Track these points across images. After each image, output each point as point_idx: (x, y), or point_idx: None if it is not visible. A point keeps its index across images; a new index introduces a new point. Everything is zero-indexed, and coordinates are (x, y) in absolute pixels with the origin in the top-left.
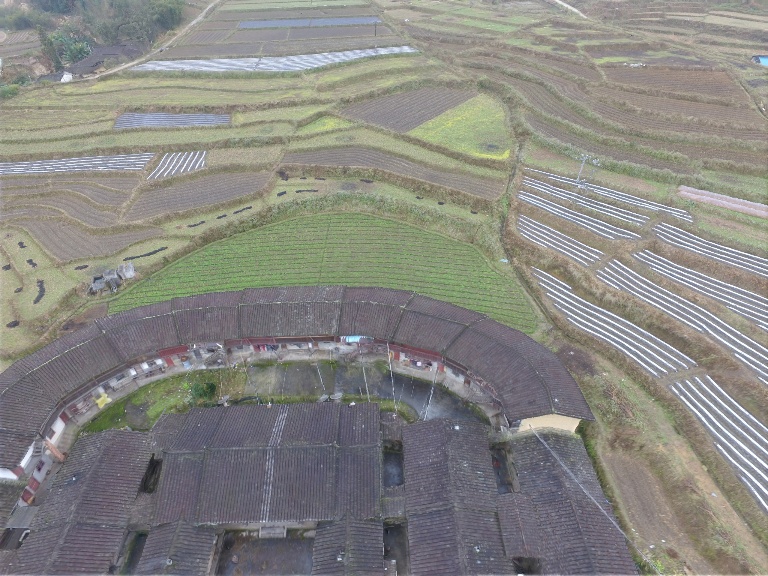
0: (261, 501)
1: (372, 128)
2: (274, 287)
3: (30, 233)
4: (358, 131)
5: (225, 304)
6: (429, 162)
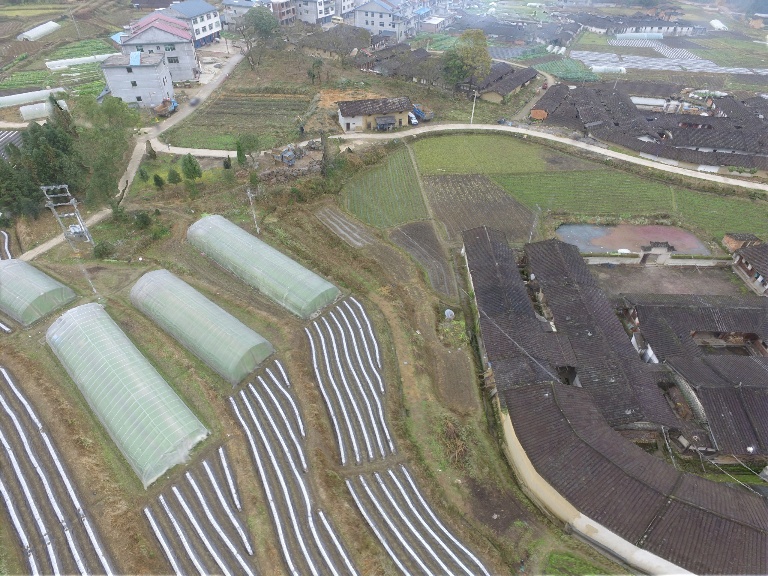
0: (766, 364)
1: None
2: None
3: None
4: None
5: None
6: None
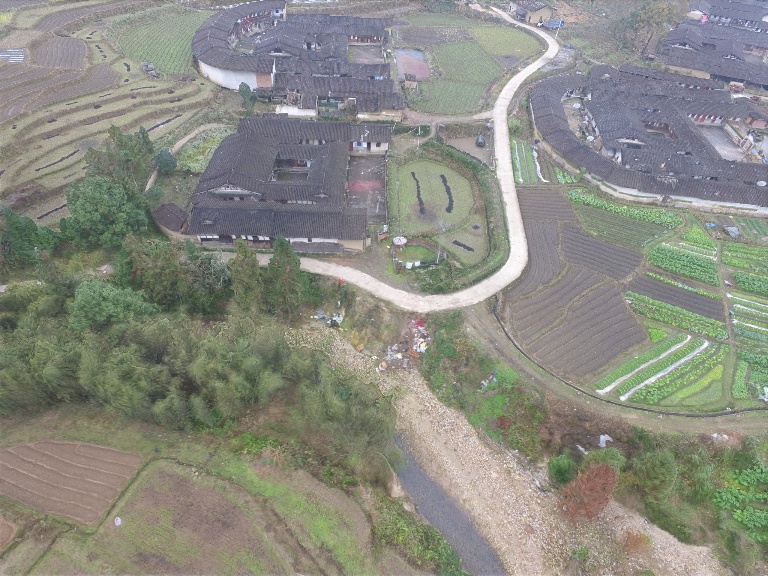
0: None
1: (27, 8)
2: (199, 27)
3: (57, 100)
4: (24, 13)
5: (208, 30)
6: (102, 2)
